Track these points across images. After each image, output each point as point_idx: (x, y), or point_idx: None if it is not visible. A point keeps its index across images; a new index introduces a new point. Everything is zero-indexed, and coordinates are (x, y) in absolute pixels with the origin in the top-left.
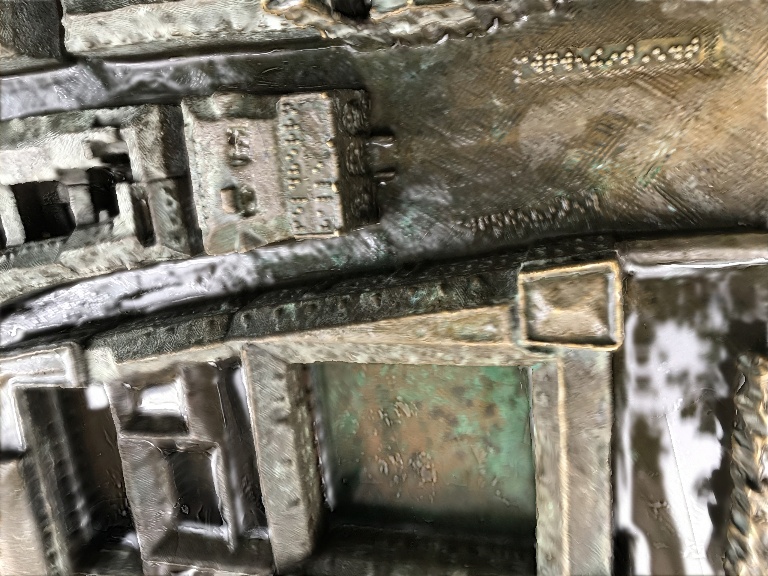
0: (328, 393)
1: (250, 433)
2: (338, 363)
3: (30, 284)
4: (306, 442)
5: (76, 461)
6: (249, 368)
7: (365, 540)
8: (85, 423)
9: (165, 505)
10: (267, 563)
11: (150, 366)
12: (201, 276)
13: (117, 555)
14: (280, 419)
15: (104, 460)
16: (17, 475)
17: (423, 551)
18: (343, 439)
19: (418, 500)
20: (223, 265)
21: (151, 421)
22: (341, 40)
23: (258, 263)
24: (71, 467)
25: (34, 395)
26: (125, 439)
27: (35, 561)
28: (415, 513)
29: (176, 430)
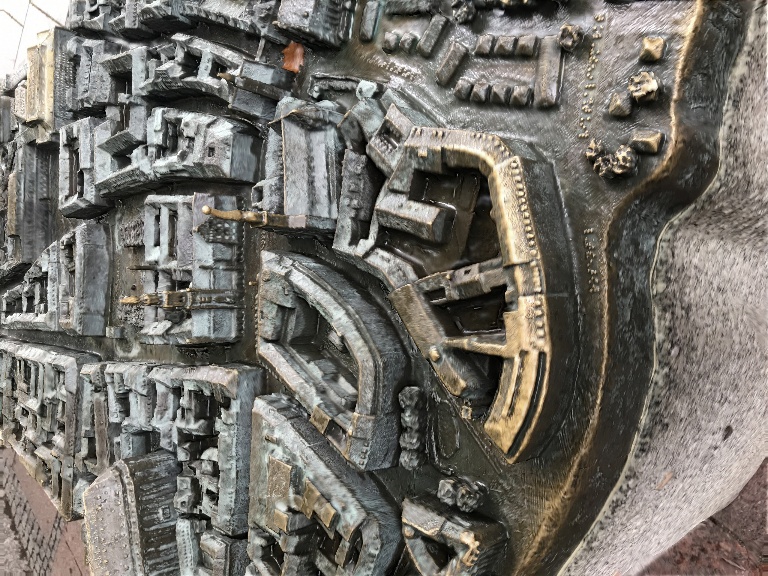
0: None
1: None
2: None
3: None
4: None
5: None
6: None
7: None
8: None
9: None
10: None
11: None
12: None
13: None
14: None
15: None
16: None
17: None
18: None
19: None
20: None
21: None
22: (4, 337)
23: None
24: None
25: None
26: None
27: None
28: None
29: None
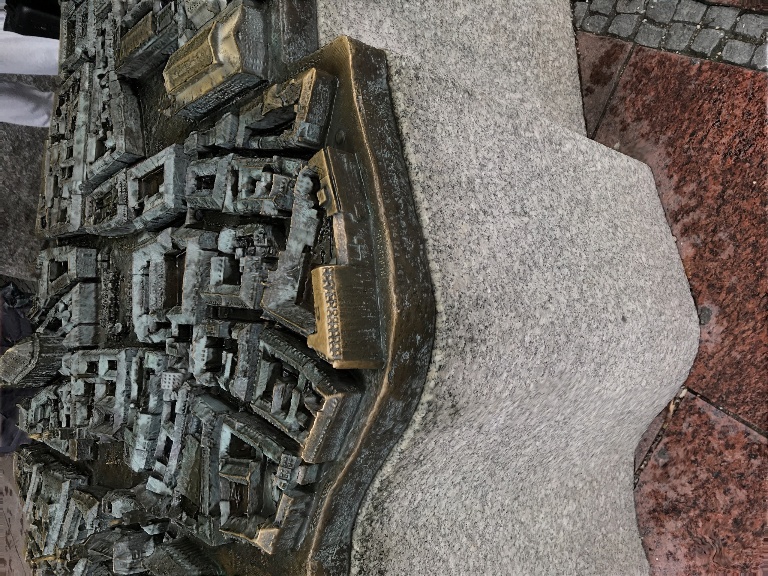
0: None
1: None
2: None
3: None
4: None
5: None
6: None
7: None
8: None
9: None
10: None
11: (118, 6)
12: None
13: None
14: None
15: None
16: None
17: None
18: None
19: None
20: None
21: None
22: None
23: None
24: None
25: None
26: None
27: None
28: None
29: None
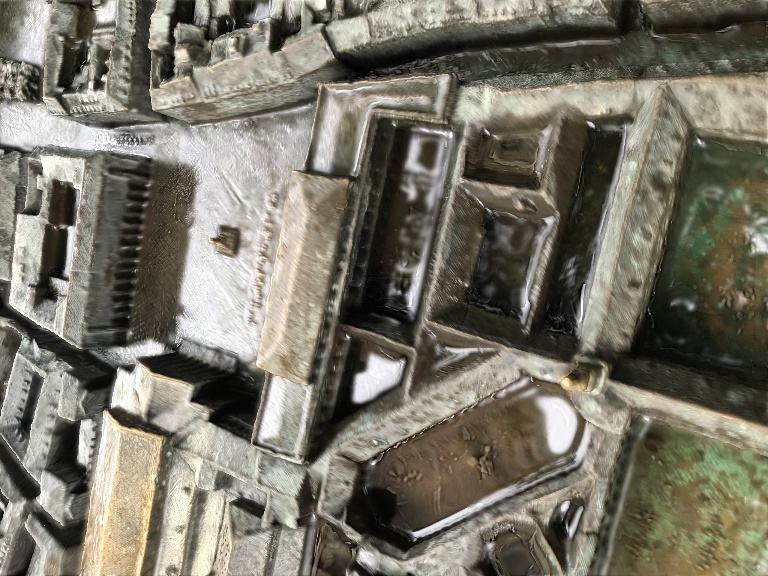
0: (690, 202)
1: (598, 212)
2: (716, 170)
3: (423, 22)
4: (663, 233)
5: (378, 223)
6: (658, 110)
7: (687, 365)
8: (396, 193)
9: (466, 274)
10: (568, 353)
11: (529, 107)
12: (584, 61)
13: (388, 321)
14: (661, 183)
15: (398, 236)
16: (345, 193)
17: (767, 387)
18: (686, 259)
19: (763, 342)
20: (617, 49)
21: (496, 174)
22: None
23: (655, 55)
24: (374, 224)
25: (379, 133)
26: (463, 186)
27: (324, 286)
28: (754, 356)
29: (524, 185)
